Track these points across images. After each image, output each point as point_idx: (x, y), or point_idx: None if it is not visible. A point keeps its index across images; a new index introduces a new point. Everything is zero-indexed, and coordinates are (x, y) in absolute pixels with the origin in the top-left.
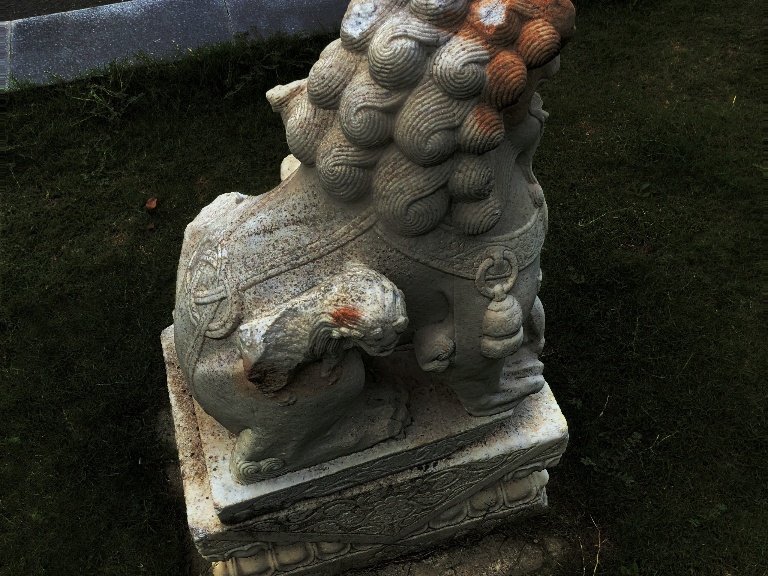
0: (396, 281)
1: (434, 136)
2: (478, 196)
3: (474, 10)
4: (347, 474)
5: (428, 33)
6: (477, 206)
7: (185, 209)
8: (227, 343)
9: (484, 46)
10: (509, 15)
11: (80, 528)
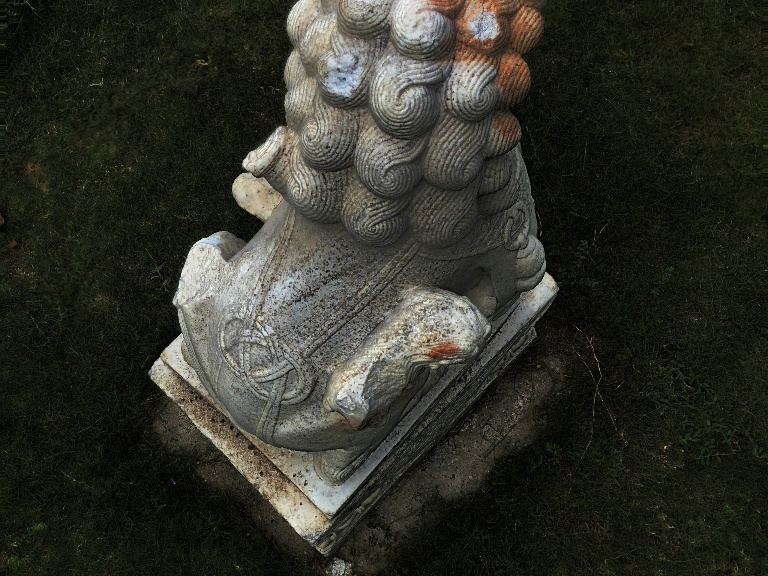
0: (445, 283)
1: (469, 165)
2: (505, 186)
3: (463, 28)
4: (414, 424)
5: (431, 72)
6: (502, 192)
7: (36, 208)
8: (307, 403)
9: (488, 62)
10: (501, 22)
11: (160, 568)
